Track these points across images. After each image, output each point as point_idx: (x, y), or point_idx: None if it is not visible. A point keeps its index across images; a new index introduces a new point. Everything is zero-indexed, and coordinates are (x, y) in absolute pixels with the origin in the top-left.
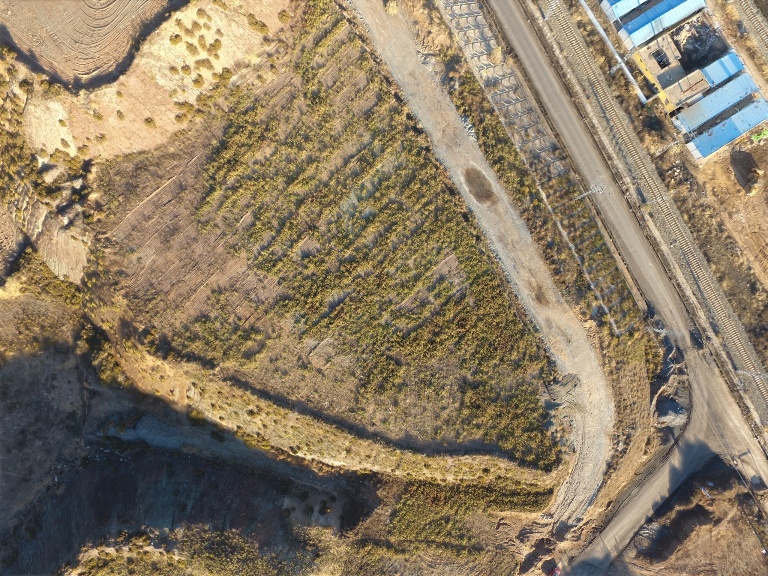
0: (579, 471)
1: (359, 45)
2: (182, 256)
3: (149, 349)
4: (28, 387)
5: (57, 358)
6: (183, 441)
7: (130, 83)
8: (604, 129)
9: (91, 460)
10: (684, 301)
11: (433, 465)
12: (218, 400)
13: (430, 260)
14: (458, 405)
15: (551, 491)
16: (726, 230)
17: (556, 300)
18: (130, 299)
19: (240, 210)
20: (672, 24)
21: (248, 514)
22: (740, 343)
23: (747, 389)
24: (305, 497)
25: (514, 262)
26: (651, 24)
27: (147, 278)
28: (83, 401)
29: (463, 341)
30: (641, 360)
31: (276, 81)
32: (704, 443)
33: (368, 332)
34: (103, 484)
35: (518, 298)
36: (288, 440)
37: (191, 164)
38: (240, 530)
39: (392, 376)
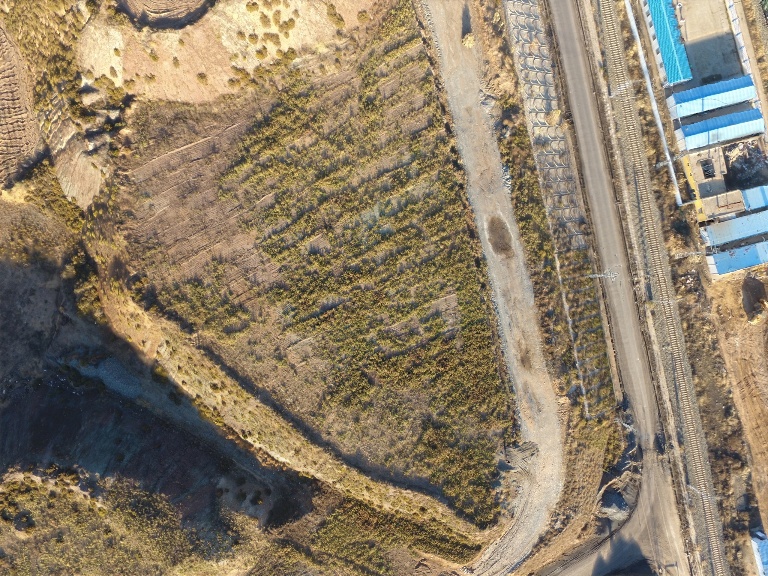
0: (511, 536)
1: (427, 66)
2: (194, 216)
3: (134, 296)
4: (4, 294)
5: (41, 275)
6: (140, 393)
7: (195, 35)
8: (634, 218)
9: (44, 384)
10: (659, 404)
11: (374, 489)
12: (186, 364)
13: (431, 293)
14: (416, 439)
15: (479, 547)
16: (719, 349)
17: (539, 368)
18: (131, 242)
19: (264, 189)
20: (728, 139)
21: (181, 483)
22: (699, 460)
23: (693, 505)
24: (242, 482)
25: (511, 319)
26: (708, 133)
27: (153, 226)
28: (54, 324)
29: (439, 380)
30: (602, 448)
31: (336, 76)
32: (637, 544)
33: (351, 344)
34: (49, 411)
35: (504, 355)
36: (242, 423)
37: (230, 130)
38: (169, 496)
39: (361, 393)
